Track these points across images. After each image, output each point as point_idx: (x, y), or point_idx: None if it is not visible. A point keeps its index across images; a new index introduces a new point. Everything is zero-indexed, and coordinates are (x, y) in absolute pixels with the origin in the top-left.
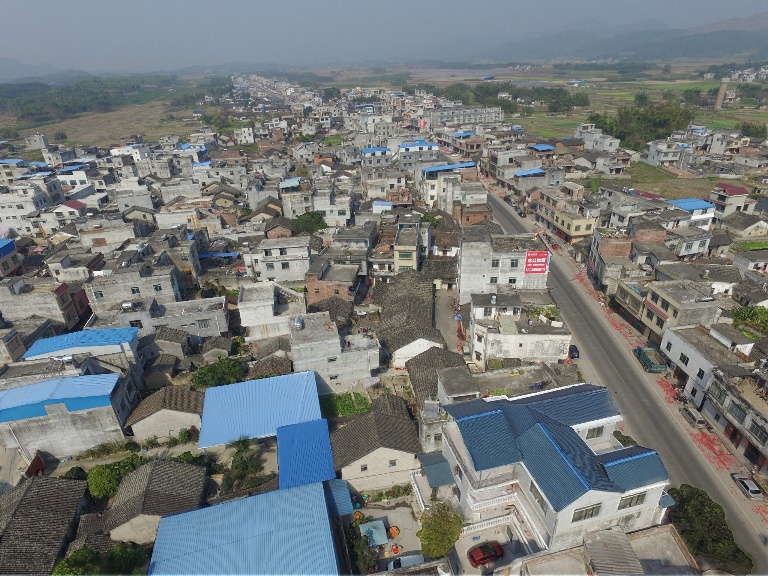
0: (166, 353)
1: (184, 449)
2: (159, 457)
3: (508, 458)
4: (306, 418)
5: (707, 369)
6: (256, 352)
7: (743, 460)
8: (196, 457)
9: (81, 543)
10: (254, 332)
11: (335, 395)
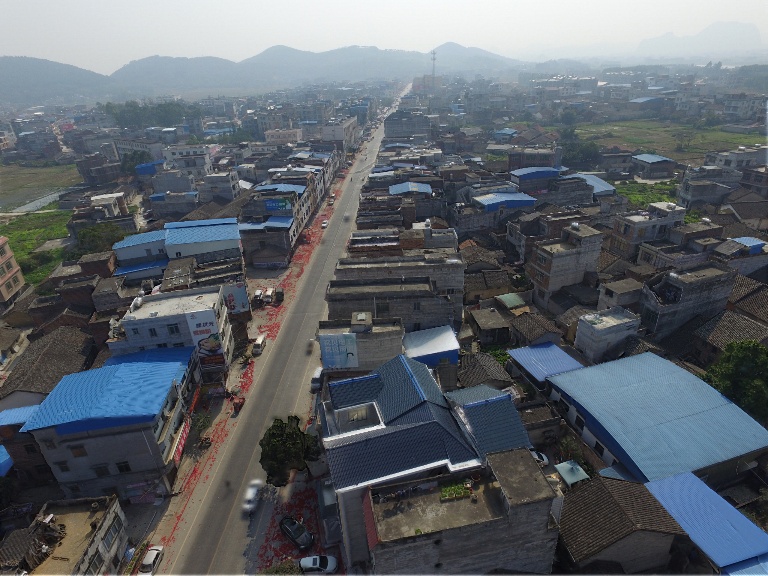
0: None
1: None
2: None
3: (456, 392)
4: (758, 575)
5: None
6: None
7: None
8: None
9: None
10: None
11: None
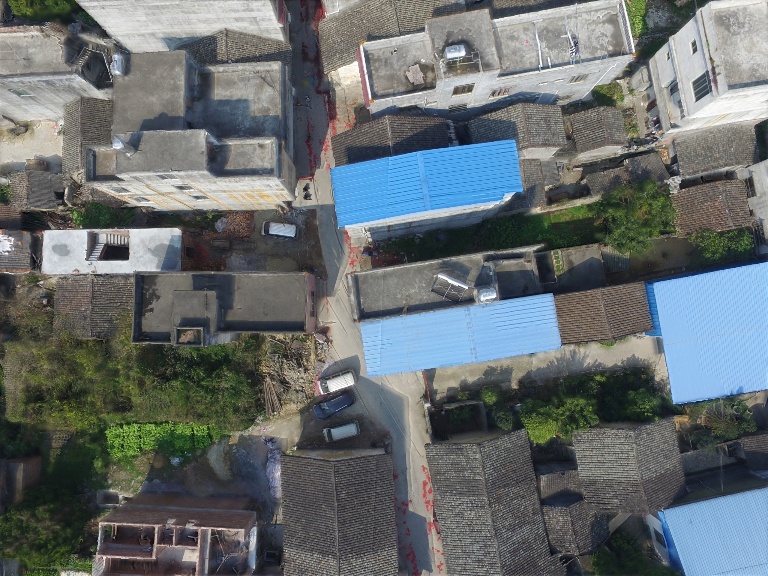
0: (526, 158)
1: (601, 349)
2: (571, 361)
3: None
4: None
5: None
6: (663, 141)
7: None
8: (634, 377)
9: (565, 517)
10: (695, 122)
11: None
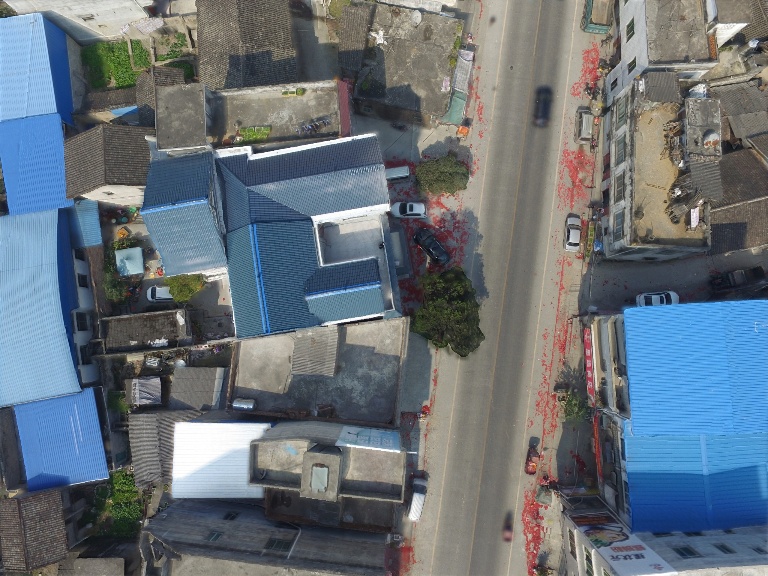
0: None
1: None
2: None
3: (208, 262)
4: (35, 108)
5: (640, 65)
6: None
7: (597, 198)
8: None
9: None
10: None
11: (104, 43)
